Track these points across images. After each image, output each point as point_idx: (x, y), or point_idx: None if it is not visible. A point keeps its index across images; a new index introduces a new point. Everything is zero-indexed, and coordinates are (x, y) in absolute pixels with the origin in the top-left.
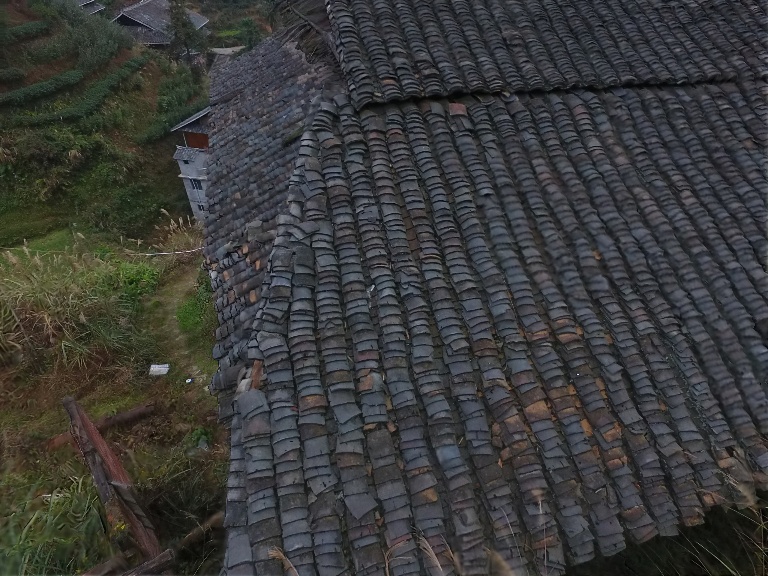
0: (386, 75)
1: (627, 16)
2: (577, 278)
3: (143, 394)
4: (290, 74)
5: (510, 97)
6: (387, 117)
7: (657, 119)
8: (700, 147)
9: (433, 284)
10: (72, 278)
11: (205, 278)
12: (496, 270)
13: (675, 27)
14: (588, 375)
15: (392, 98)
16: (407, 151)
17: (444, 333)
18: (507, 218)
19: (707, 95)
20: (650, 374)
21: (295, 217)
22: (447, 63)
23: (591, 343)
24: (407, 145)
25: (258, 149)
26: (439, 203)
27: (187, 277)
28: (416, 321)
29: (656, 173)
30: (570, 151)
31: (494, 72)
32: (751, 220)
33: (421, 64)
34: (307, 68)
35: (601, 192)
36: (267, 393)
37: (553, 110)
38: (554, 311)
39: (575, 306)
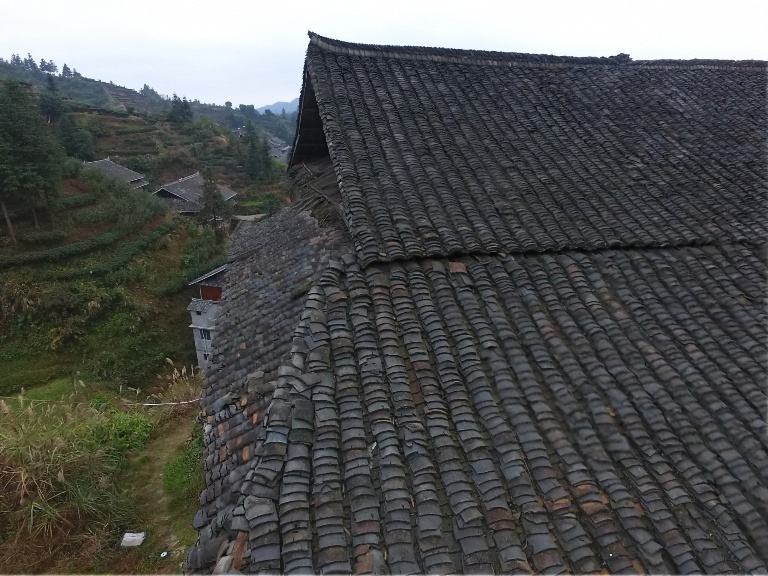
0: (390, 238)
1: (604, 191)
2: (594, 437)
3: (109, 571)
4: (303, 237)
5: (506, 257)
6: (391, 274)
7: (648, 277)
8: (695, 303)
9: (439, 442)
10: (61, 430)
11: (200, 431)
12: (506, 427)
13: (649, 200)
14: (623, 556)
15: (396, 257)
16: (410, 305)
17: (453, 500)
18: (513, 371)
19: (691, 256)
20: (695, 555)
21: (297, 368)
22: (446, 228)
23: (620, 514)
24: (410, 299)
25: (268, 302)
26: (443, 355)
27: (181, 430)
28: (422, 485)
29: (657, 327)
30: (569, 306)
31: (489, 236)
32: (765, 375)
33: (422, 229)
34: (319, 232)
35: (605, 346)
36: (248, 575)
37: (548, 269)
38: (573, 475)
39: (596, 469)
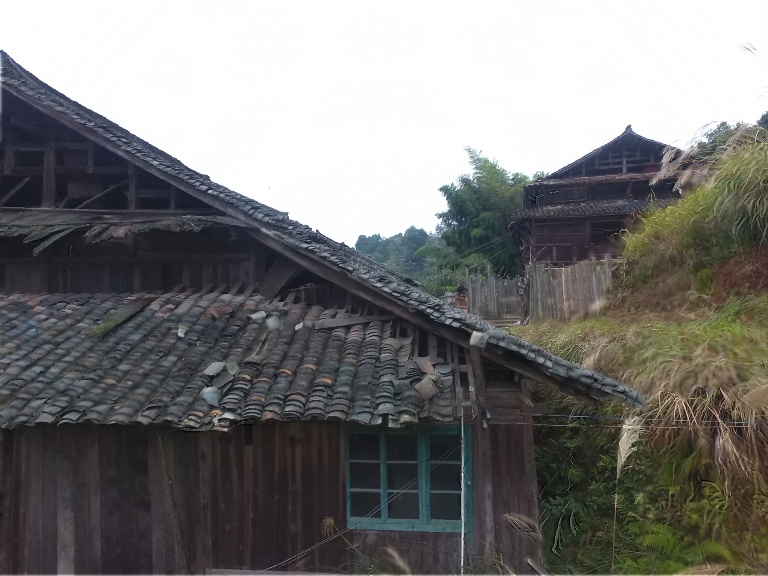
0: None
1: None
2: None
3: None
4: None
5: None
6: None
7: None
8: None
9: None
10: None
11: None
12: None
13: None
14: None
15: None
16: None
17: None
18: None
19: None
20: None
21: None
22: None
23: None
24: None
25: (38, 358)
26: None
27: None
28: None
29: None
30: None
31: None
32: None
33: None
34: None
35: None
36: None
37: None
38: None
39: None
